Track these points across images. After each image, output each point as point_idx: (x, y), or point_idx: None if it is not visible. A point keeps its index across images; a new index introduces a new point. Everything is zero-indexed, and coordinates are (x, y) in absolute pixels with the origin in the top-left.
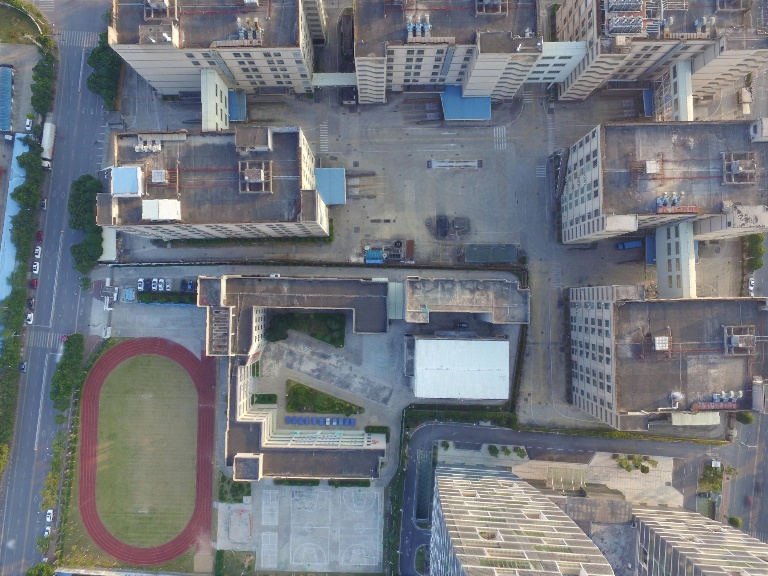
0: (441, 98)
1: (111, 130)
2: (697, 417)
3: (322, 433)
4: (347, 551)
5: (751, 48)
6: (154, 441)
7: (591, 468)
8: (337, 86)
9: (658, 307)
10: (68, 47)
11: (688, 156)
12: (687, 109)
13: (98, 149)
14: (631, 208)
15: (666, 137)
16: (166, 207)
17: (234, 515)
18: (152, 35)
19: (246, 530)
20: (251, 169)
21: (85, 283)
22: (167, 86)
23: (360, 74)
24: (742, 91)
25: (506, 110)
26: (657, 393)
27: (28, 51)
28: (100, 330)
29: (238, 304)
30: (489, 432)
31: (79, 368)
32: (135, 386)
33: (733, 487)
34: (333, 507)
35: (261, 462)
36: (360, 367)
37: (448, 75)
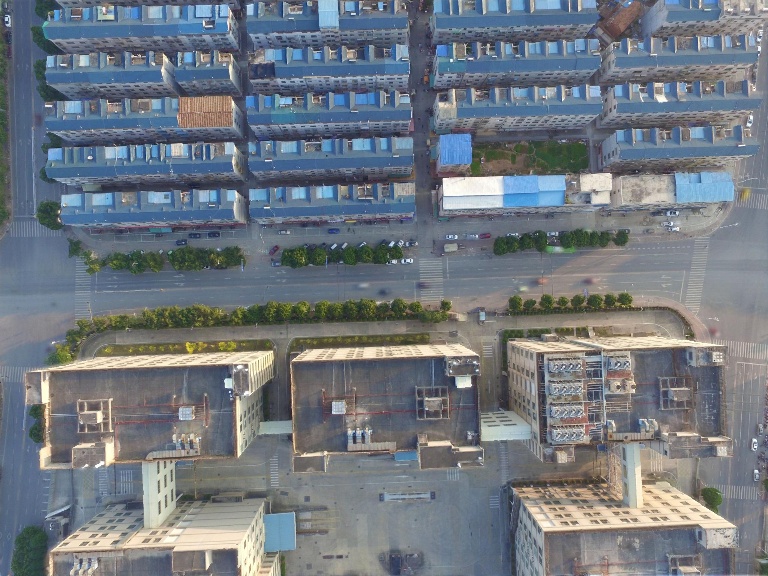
0: None
1: None
2: None
3: None
4: None
5: (695, 456)
6: None
7: None
8: None
9: None
10: (12, 384)
11: (634, 558)
12: (635, 481)
13: (44, 488)
14: None
15: (611, 539)
16: None
17: None
18: (85, 458)
19: None
20: None
21: None
22: None
23: None
24: None
25: None
26: None
27: None
28: None
29: None
30: None
31: None
32: None
33: None
34: None
35: None
36: None
37: None
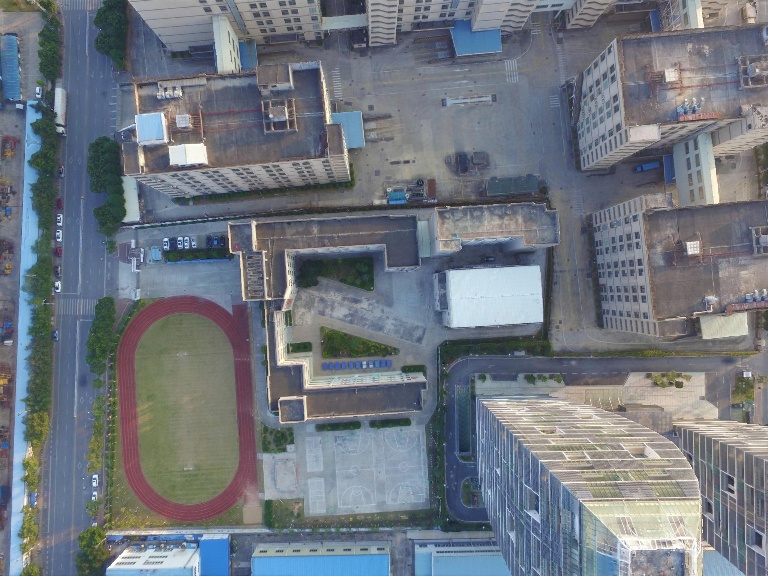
0: (451, 34)
1: (122, 92)
2: (726, 329)
3: (360, 376)
4: (394, 490)
5: None
6: (193, 399)
7: (626, 389)
8: (347, 29)
9: (686, 214)
10: (71, 11)
11: (704, 64)
12: (697, 22)
13: (111, 112)
14: (652, 119)
15: (681, 46)
16: (193, 151)
17: (279, 464)
18: None
19: (292, 478)
20: (275, 107)
21: (110, 246)
22: (177, 41)
23: (373, 9)
24: (746, 6)
25: (516, 43)
26: (691, 298)
27: (31, 18)
28: (129, 293)
29: (269, 249)
30: (524, 362)
31: (112, 331)
32: (169, 346)
33: (765, 396)
34: (376, 448)
35: (305, 404)
36: (392, 309)
37: (458, 8)
